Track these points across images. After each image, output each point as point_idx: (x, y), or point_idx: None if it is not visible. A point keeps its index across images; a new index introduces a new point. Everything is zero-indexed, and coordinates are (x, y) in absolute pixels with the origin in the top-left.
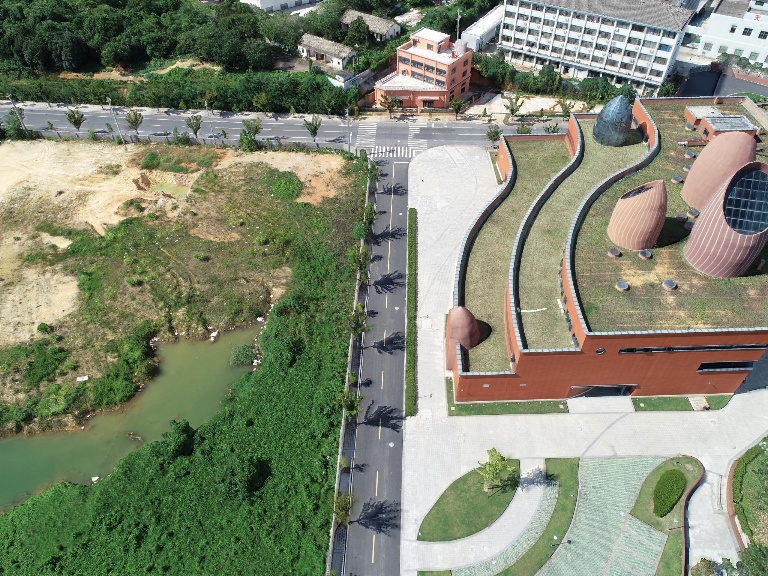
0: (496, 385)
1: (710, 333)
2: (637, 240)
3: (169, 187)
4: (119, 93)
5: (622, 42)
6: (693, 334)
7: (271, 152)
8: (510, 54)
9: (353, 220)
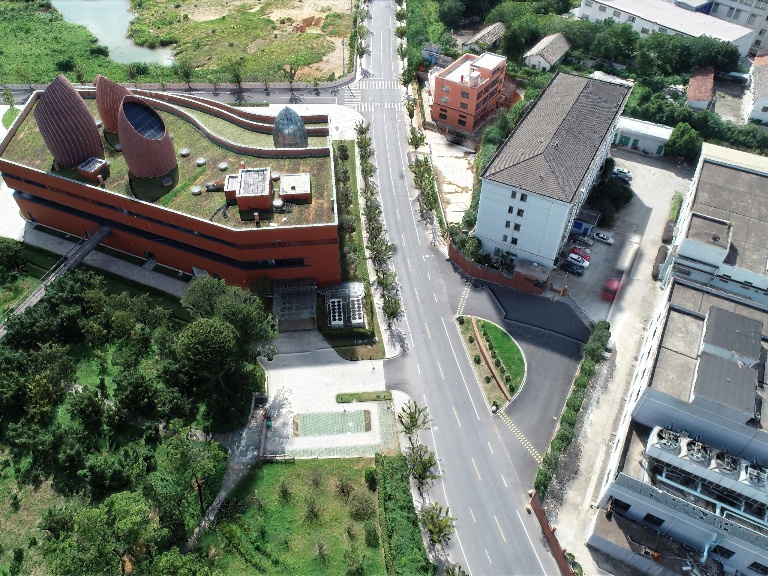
0: None
1: None
2: None
3: None
4: None
5: None
6: None
7: (349, 52)
8: None
9: None
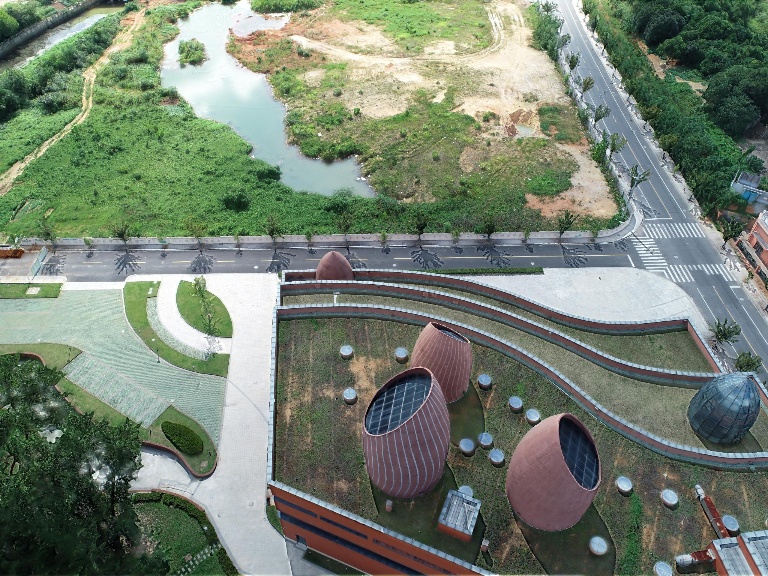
0: None
1: None
2: None
3: (528, 131)
4: (637, 73)
5: None
6: None
7: (599, 170)
8: None
9: (508, 229)
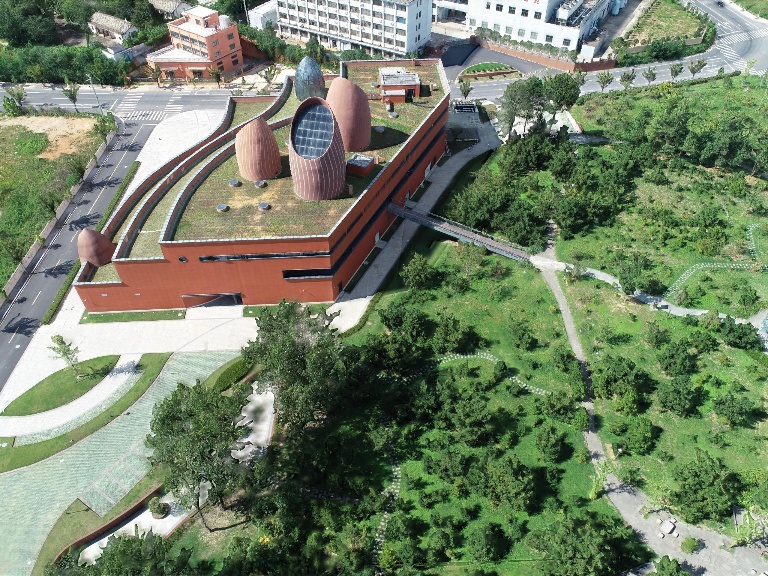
0: (113, 295)
1: (267, 241)
2: (252, 171)
3: None
4: None
5: (369, 16)
6: (253, 242)
7: (33, 117)
8: (289, 30)
9: None
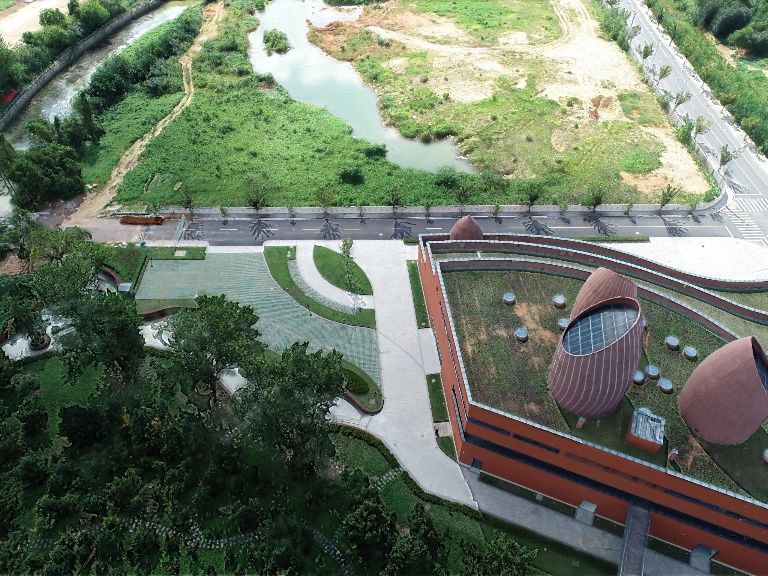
0: None
1: None
2: None
3: (610, 116)
4: (708, 62)
5: None
6: None
7: (685, 150)
8: None
9: (609, 202)
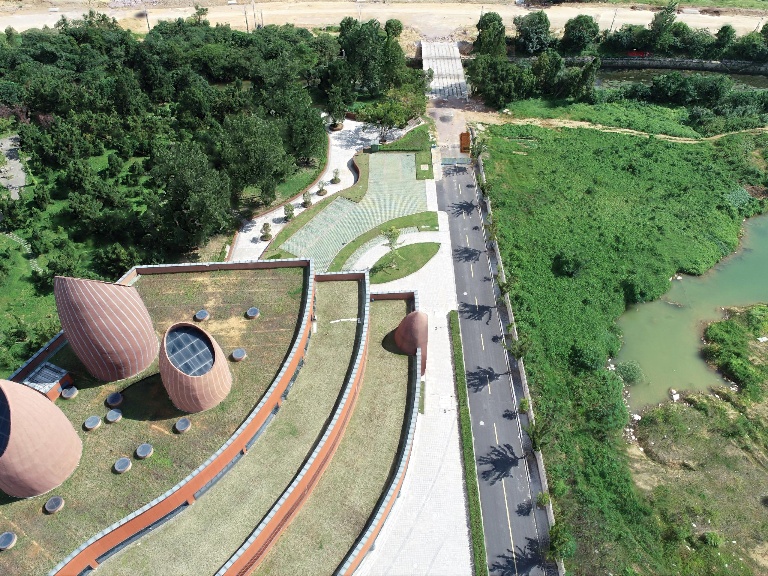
0: None
1: None
2: None
3: None
4: None
5: None
6: None
7: None
8: None
9: None
